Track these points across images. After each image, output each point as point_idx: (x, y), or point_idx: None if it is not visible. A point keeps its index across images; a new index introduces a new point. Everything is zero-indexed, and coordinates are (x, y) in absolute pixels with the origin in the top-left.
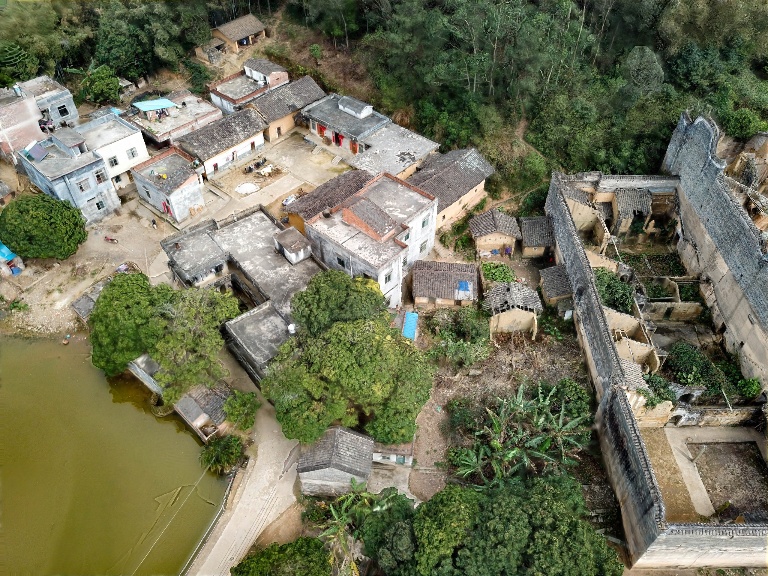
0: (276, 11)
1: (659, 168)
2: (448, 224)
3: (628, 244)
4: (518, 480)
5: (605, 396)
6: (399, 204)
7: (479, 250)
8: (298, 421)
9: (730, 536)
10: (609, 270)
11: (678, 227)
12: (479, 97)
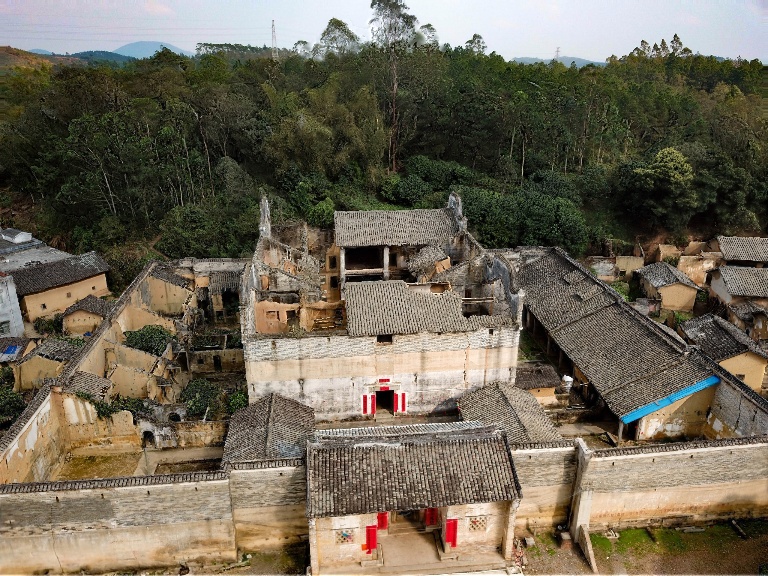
0: (7, 186)
1: None
2: (52, 315)
3: (229, 324)
4: None
5: None
6: None
7: (65, 330)
8: None
9: (54, 497)
10: (168, 329)
11: None
12: (119, 216)
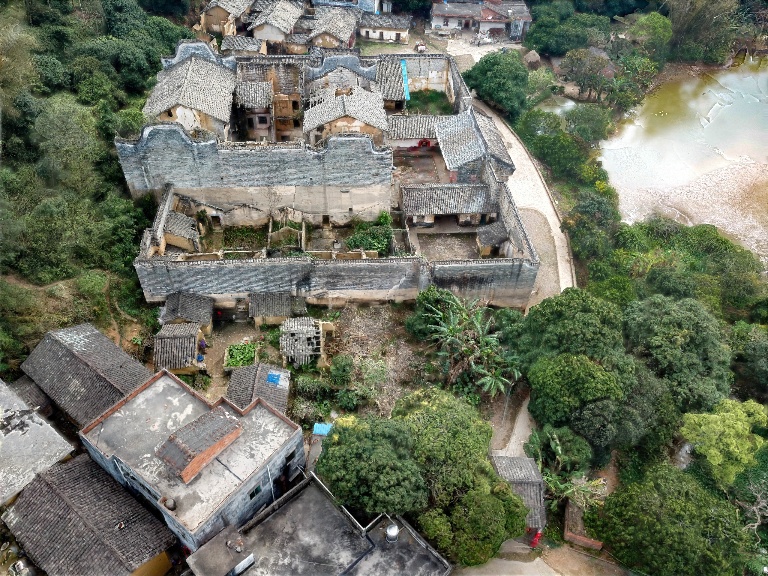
0: None
1: (132, 199)
2: None
3: None
4: (501, 349)
5: (424, 281)
6: (162, 414)
7: (204, 368)
8: (522, 504)
9: None
10: None
11: (209, 212)
12: None
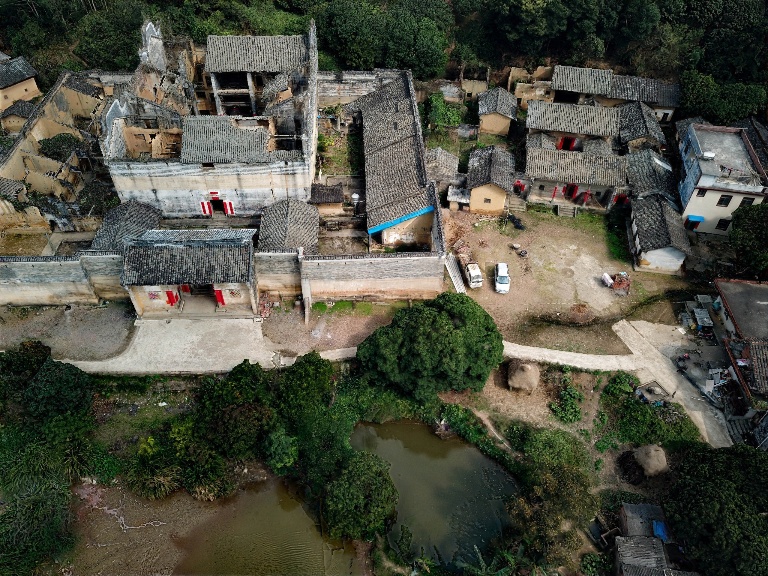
0: None
1: None
2: None
3: None
4: None
5: None
6: None
7: (4, 130)
8: None
9: None
10: (77, 137)
11: None
12: (41, 20)
